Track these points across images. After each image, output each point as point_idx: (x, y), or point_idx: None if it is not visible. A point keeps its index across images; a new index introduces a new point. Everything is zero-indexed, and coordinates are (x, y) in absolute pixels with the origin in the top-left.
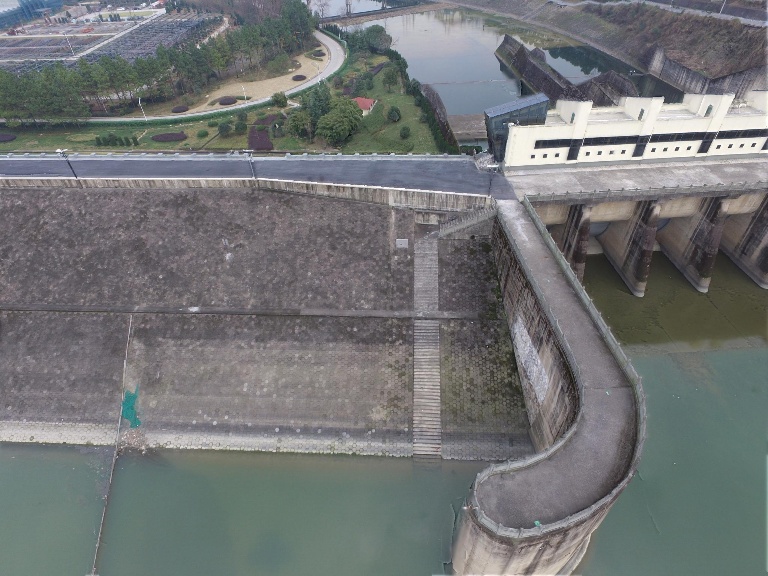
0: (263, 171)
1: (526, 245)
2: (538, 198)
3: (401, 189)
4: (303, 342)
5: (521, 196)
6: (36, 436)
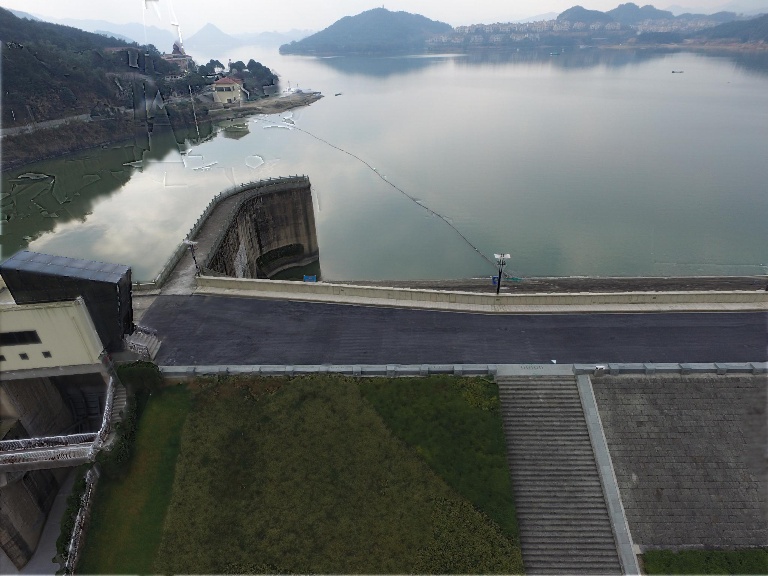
0: (513, 336)
1: (202, 254)
2: (139, 287)
3: (298, 282)
4: (402, 286)
5: (150, 299)
6: (567, 277)
